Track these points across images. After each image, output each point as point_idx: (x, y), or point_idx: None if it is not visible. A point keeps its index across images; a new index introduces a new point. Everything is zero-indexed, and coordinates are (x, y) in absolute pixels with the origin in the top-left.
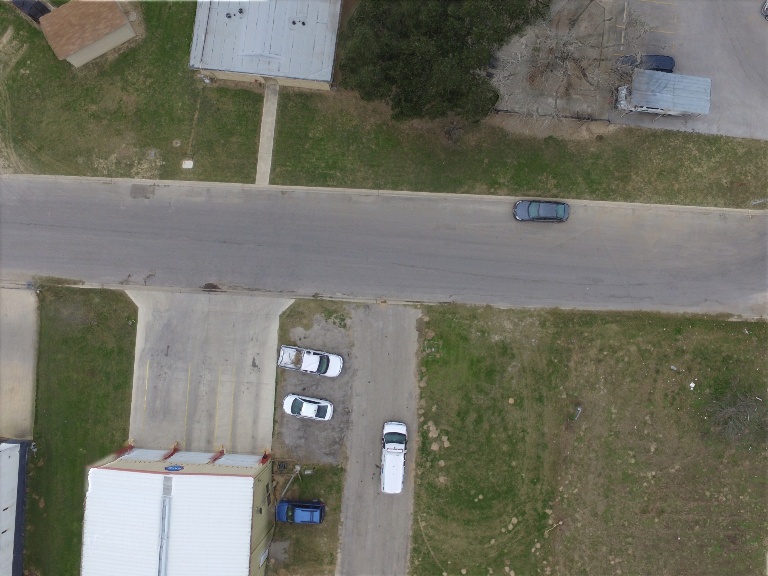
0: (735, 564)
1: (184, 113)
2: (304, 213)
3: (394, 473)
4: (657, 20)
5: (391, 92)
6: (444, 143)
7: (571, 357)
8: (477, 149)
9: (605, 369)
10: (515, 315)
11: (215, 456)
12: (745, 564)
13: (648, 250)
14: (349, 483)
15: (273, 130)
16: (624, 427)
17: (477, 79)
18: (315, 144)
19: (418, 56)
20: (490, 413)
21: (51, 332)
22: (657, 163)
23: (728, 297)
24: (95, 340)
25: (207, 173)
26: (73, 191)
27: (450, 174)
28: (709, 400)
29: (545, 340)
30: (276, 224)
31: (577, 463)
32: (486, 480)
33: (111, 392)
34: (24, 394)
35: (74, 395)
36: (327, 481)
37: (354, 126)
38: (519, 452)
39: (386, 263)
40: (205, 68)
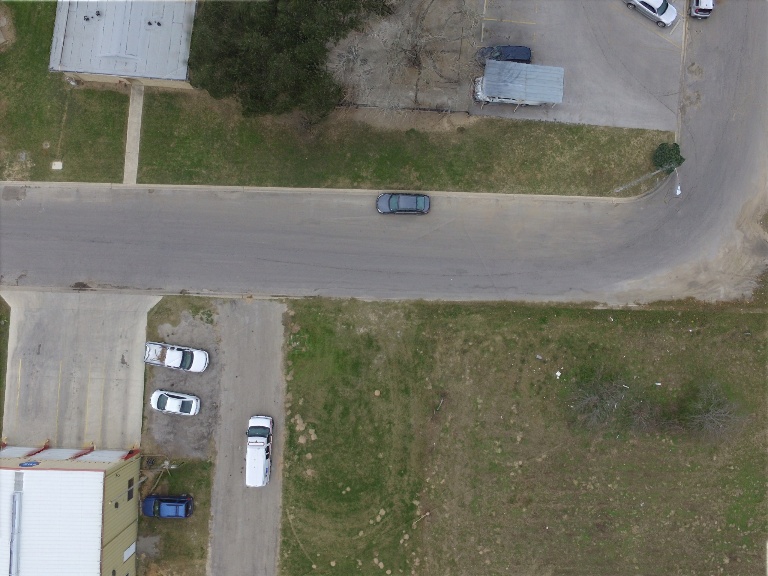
0: (605, 553)
1: (53, 115)
2: (171, 211)
3: (255, 466)
4: (518, 11)
5: (235, 89)
6: (306, 138)
7: (436, 348)
8: (339, 144)
9: (470, 359)
10: (380, 307)
11: None
12: (615, 553)
13: (512, 240)
14: (218, 477)
15: (139, 130)
16: (490, 417)
17: (317, 74)
18: (180, 143)
19: (253, 52)
20: (356, 405)
21: None
22: (519, 153)
23: (593, 285)
24: None
25: (76, 174)
26: None
27: (313, 169)
28: (575, 389)
29: (410, 332)
30: (143, 222)
31: (443, 454)
32: (353, 472)
33: None
34: None
35: None
36: (196, 476)
37: (218, 124)
38: (386, 444)
39: (251, 258)
40: (64, 70)
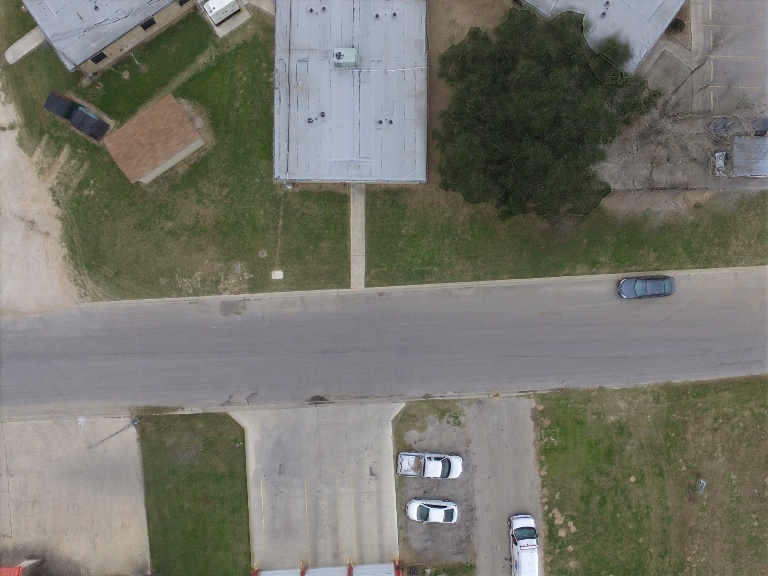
0: None
1: (267, 222)
2: (405, 313)
3: (530, 570)
4: (744, 76)
5: (500, 194)
6: (542, 227)
7: (688, 429)
8: (576, 229)
9: (722, 437)
10: (629, 394)
11: (345, 572)
12: None
13: (754, 313)
14: None
15: (363, 231)
16: (745, 491)
17: (589, 173)
18: (409, 241)
19: (532, 160)
20: (613, 494)
21: (155, 463)
22: (756, 224)
23: None
24: (203, 467)
25: (299, 282)
26: (158, 315)
27: (551, 258)
28: None
29: (660, 415)
30: (377, 328)
31: (702, 532)
32: (615, 560)
33: (226, 517)
34: (135, 530)
35: (188, 525)
36: None
37: (447, 218)
38: (645, 528)
39: (494, 356)
40: (292, 179)
